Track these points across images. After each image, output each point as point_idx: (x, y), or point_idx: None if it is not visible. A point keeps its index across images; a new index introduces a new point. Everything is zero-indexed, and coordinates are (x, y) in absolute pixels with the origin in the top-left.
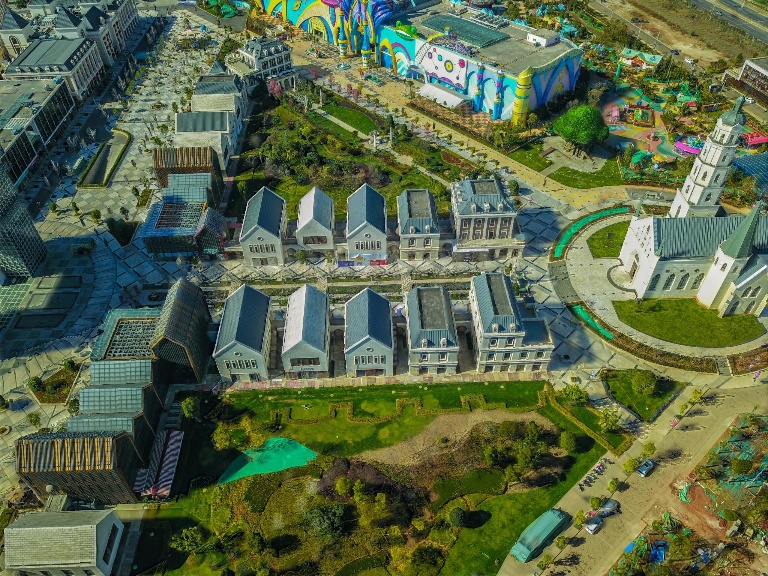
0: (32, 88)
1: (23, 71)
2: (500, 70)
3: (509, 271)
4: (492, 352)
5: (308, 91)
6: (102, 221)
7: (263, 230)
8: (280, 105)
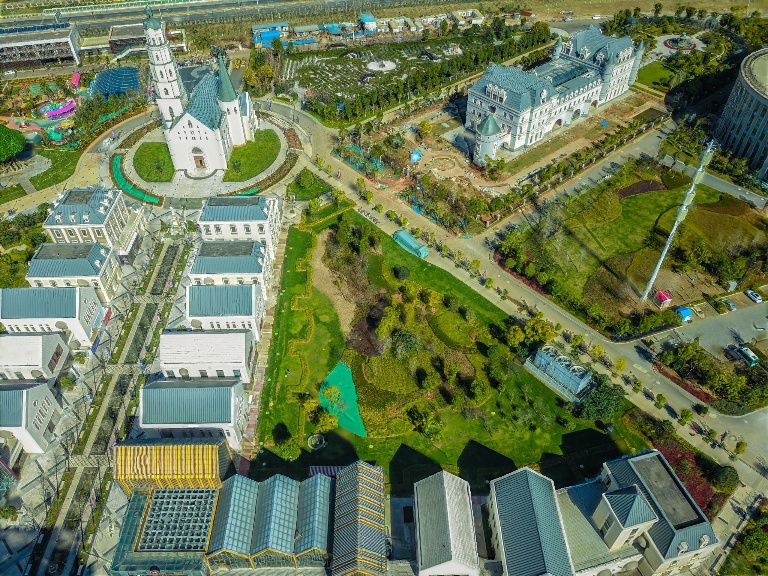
0: None
1: None
2: None
3: (165, 228)
4: None
5: None
6: None
7: (32, 389)
8: None
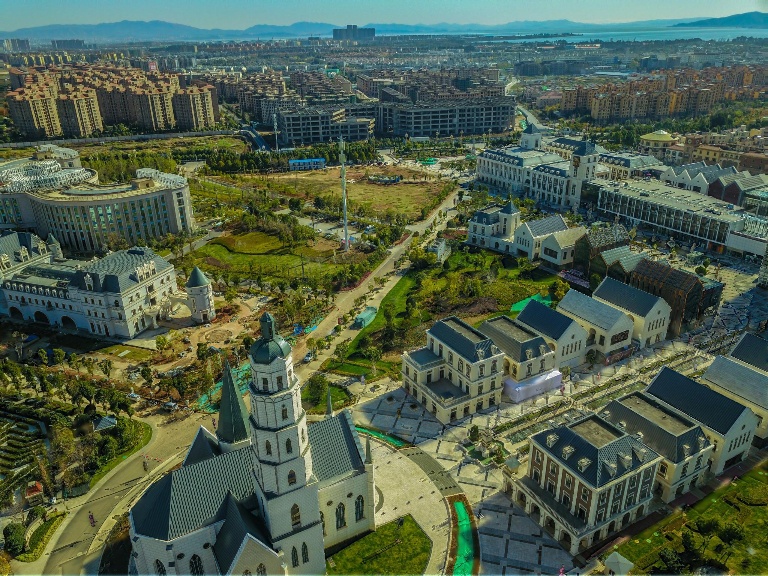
0: None
1: None
2: None
3: None
4: None
5: None
6: None
7: None
8: None
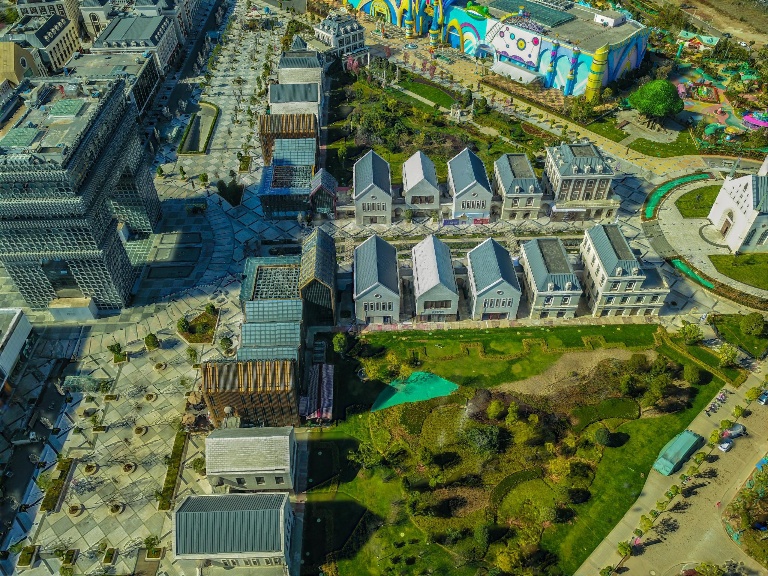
0: (123, 61)
1: (110, 46)
2: (576, 47)
3: None
4: (612, 296)
5: (382, 68)
6: (209, 184)
7: (378, 188)
8: (357, 81)
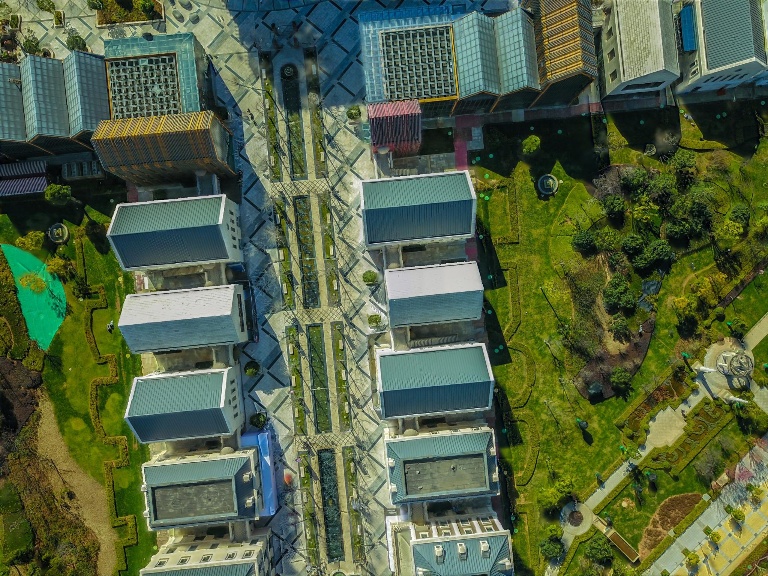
0: None
1: None
2: None
3: None
4: None
5: None
6: None
7: (363, 220)
8: None
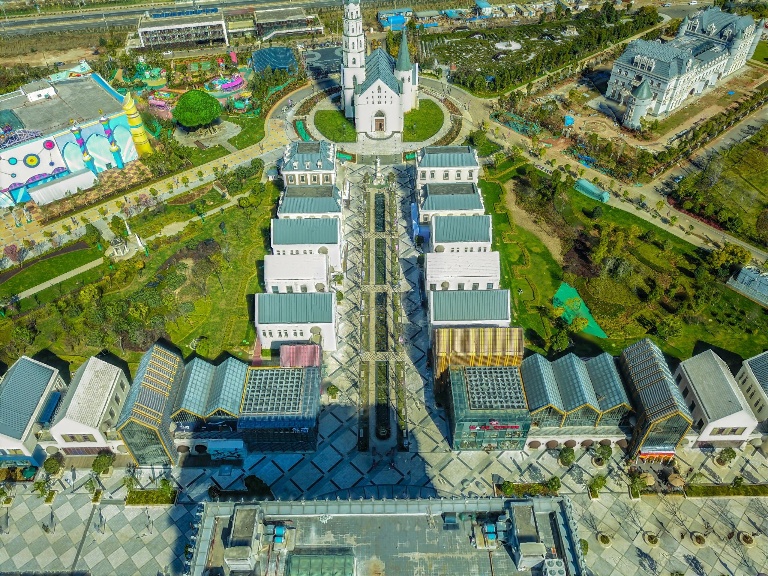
0: None
1: None
2: (102, 117)
3: None
4: None
5: None
6: None
7: None
8: None
